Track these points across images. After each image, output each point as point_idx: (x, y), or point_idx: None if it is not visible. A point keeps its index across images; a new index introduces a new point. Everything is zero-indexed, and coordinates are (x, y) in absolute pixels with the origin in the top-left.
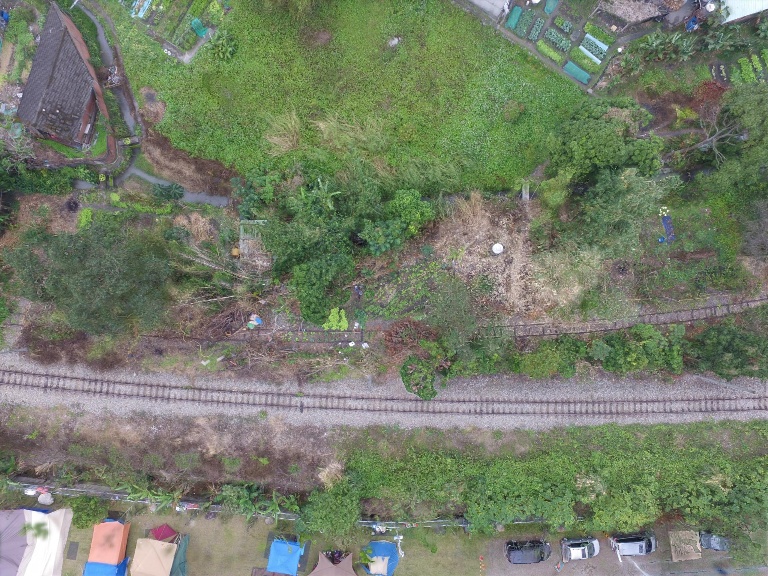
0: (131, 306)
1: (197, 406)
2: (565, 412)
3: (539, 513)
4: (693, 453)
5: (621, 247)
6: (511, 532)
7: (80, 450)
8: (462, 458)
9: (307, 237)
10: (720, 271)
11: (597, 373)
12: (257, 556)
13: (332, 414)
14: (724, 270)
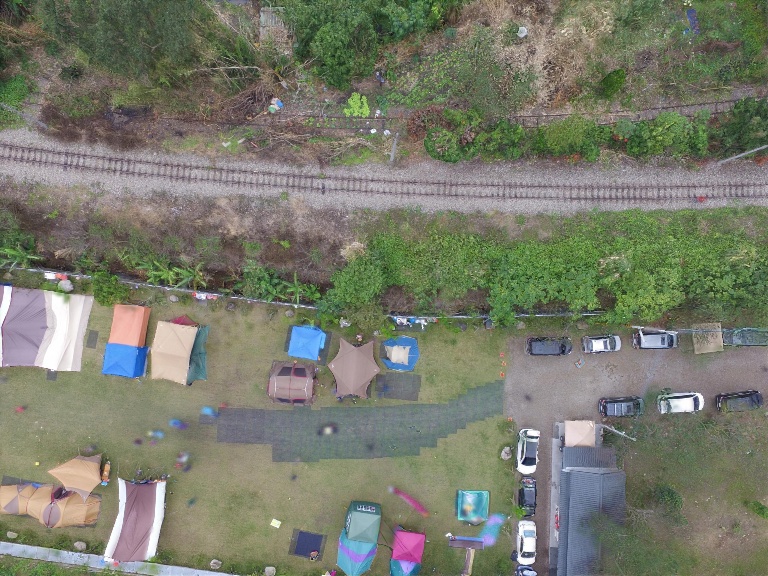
0: (156, 31)
1: (218, 186)
2: (588, 197)
3: (562, 296)
4: (717, 239)
5: (649, 2)
6: (532, 329)
7: (100, 232)
8: (484, 241)
9: (331, 0)
10: (745, 65)
11: (621, 160)
12: (277, 349)
13: (354, 196)
14: (749, 64)
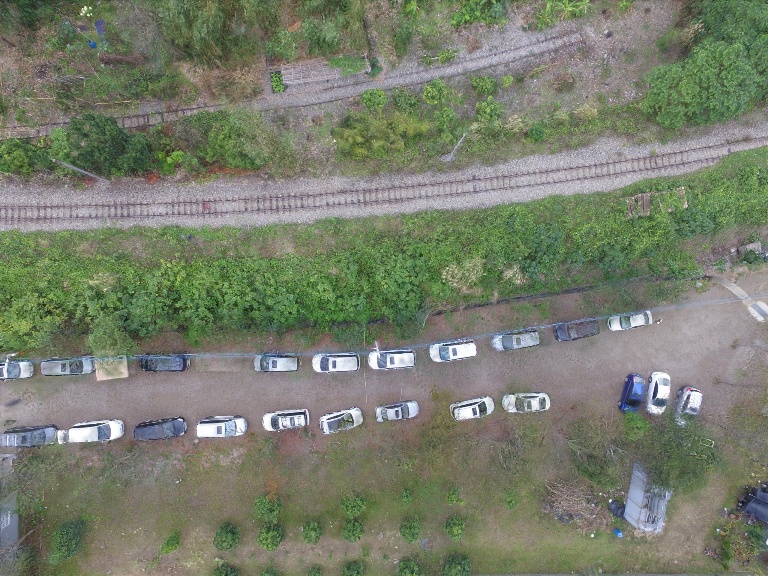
0: None
1: None
2: None
3: None
4: (100, 261)
5: None
6: None
7: None
8: None
9: None
10: (157, 78)
11: (3, 178)
12: None
13: None
14: (161, 77)
